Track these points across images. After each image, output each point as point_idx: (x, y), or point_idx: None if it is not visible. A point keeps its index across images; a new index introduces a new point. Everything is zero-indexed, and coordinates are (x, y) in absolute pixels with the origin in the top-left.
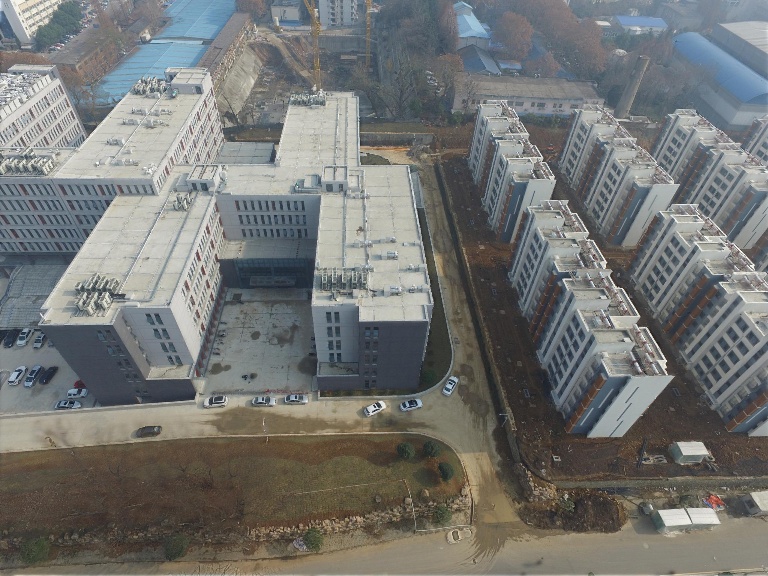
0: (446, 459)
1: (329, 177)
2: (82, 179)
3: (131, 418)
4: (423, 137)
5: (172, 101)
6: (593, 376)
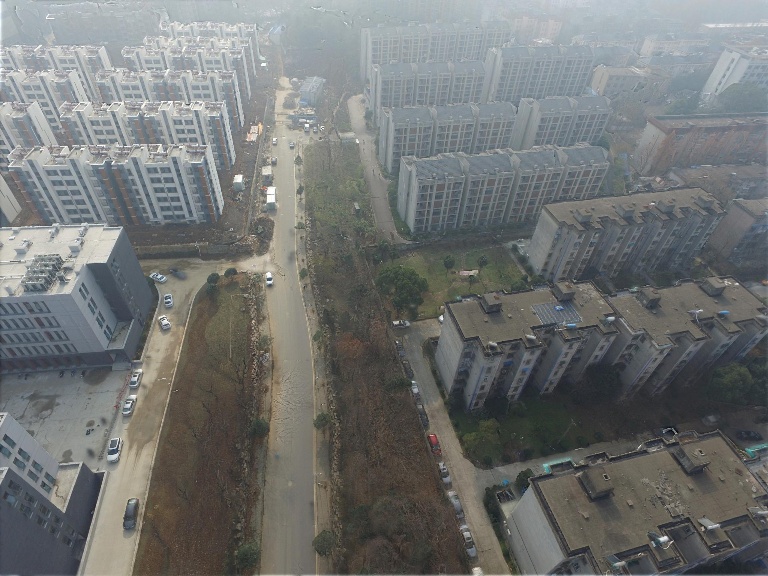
0: (220, 280)
1: None
2: None
3: (103, 549)
4: None
5: None
6: (195, 176)
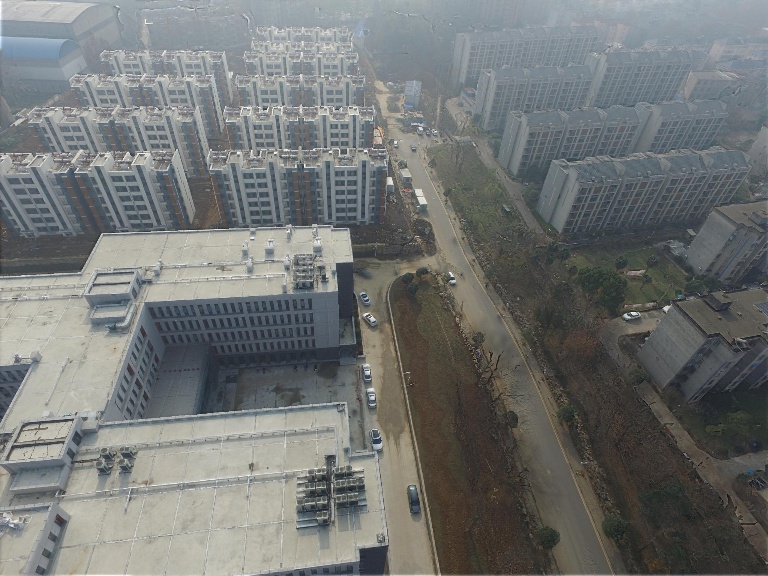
0: None
1: (117, 288)
2: None
3: (399, 532)
4: None
5: None
6: (377, 179)
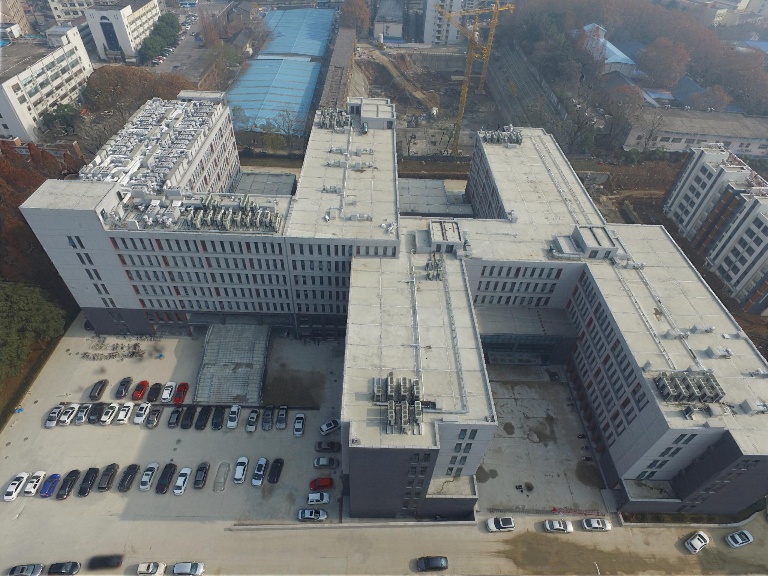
0: None
1: (591, 241)
2: (320, 238)
3: (400, 541)
4: (597, 176)
5: (364, 137)
6: None
